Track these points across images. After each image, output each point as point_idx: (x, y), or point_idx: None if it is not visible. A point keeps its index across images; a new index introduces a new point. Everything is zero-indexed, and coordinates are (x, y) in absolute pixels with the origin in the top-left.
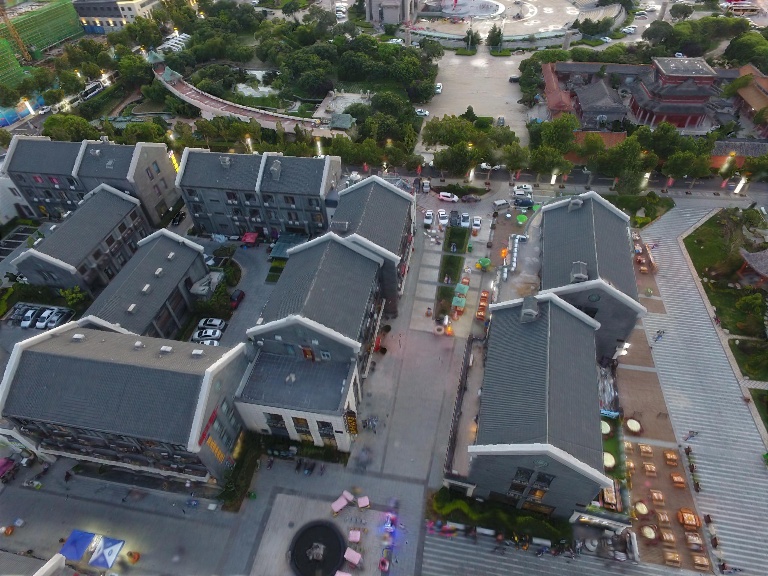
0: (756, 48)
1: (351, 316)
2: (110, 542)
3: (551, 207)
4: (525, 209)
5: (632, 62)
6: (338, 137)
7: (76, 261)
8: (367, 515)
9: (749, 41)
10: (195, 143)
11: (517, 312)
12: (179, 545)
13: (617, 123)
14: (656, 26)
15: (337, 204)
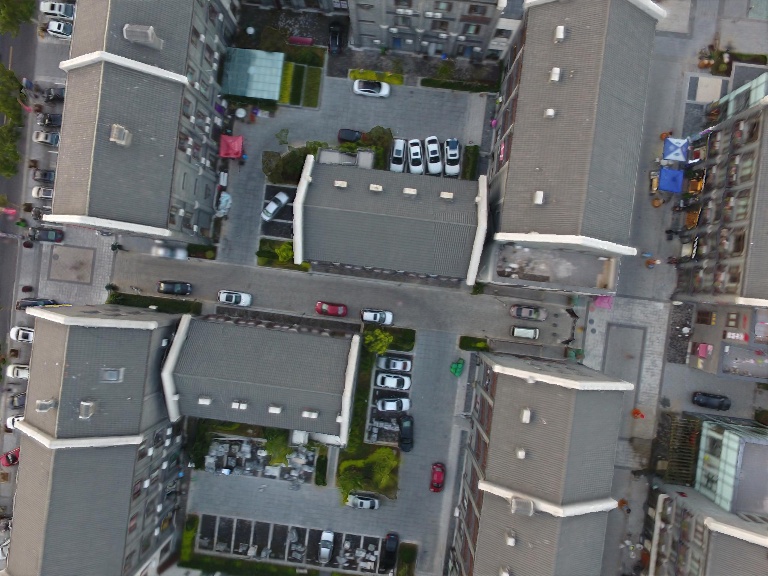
0: None
1: None
2: (669, 148)
3: None
4: None
5: None
6: None
7: (338, 344)
8: None
9: None
10: None
11: None
12: (653, 101)
13: None
14: None
15: None
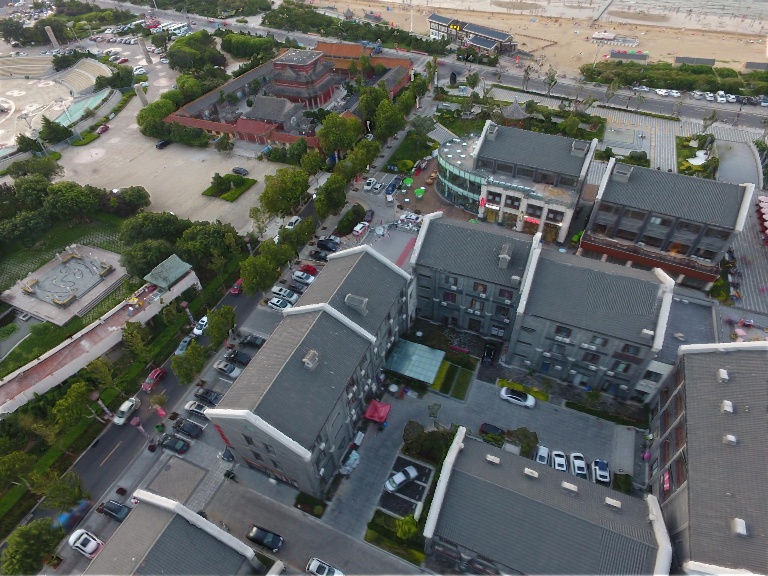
0: (252, 42)
1: None
2: None
3: (479, 148)
4: (398, 191)
5: (218, 83)
6: (249, 263)
7: None
8: (742, 338)
9: (242, 40)
10: None
11: (613, 183)
12: None
13: (309, 116)
14: (178, 54)
15: None
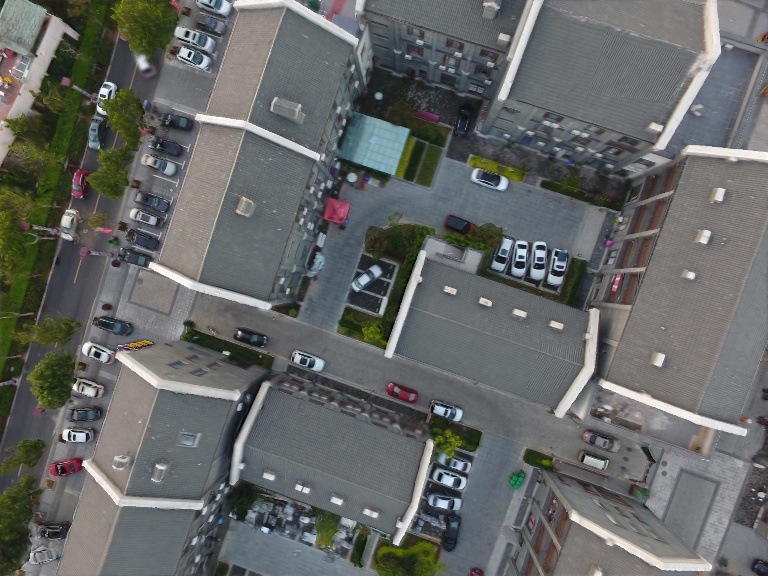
0: None
1: (666, 5)
2: None
3: None
4: None
5: None
6: (125, 16)
7: (411, 445)
8: None
9: None
10: (4, 344)
11: None
12: None
13: None
14: None
15: (359, 30)
